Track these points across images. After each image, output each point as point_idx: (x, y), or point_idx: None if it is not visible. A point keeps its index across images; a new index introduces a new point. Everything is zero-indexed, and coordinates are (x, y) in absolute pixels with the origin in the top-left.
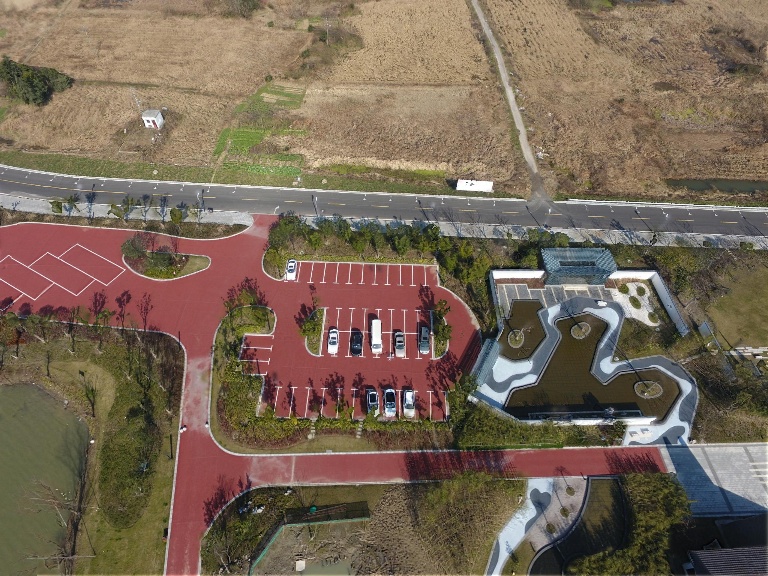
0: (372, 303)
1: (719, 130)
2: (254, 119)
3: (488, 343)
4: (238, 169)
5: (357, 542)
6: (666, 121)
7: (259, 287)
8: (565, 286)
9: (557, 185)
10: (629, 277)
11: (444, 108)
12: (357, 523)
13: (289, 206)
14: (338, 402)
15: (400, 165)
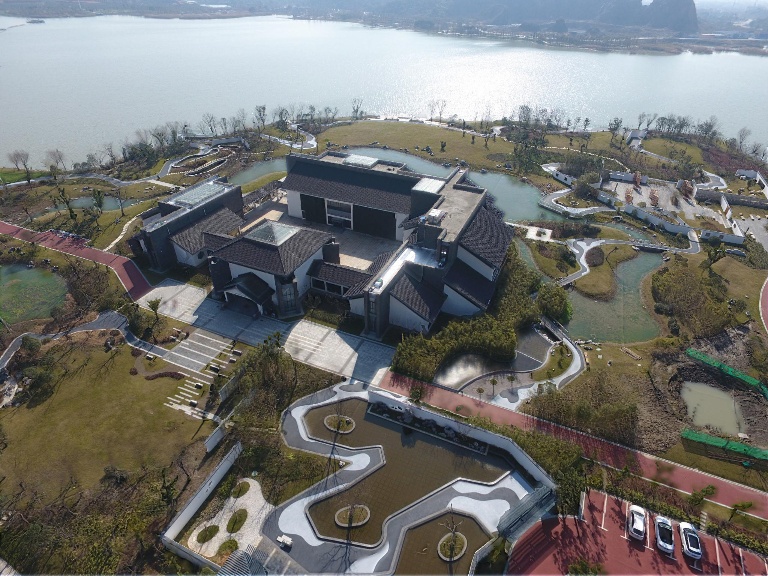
0: None
1: None
2: None
3: (513, 536)
4: None
5: (693, 425)
6: None
7: None
8: None
9: None
10: None
11: None
12: None
13: None
14: (744, 570)
15: None
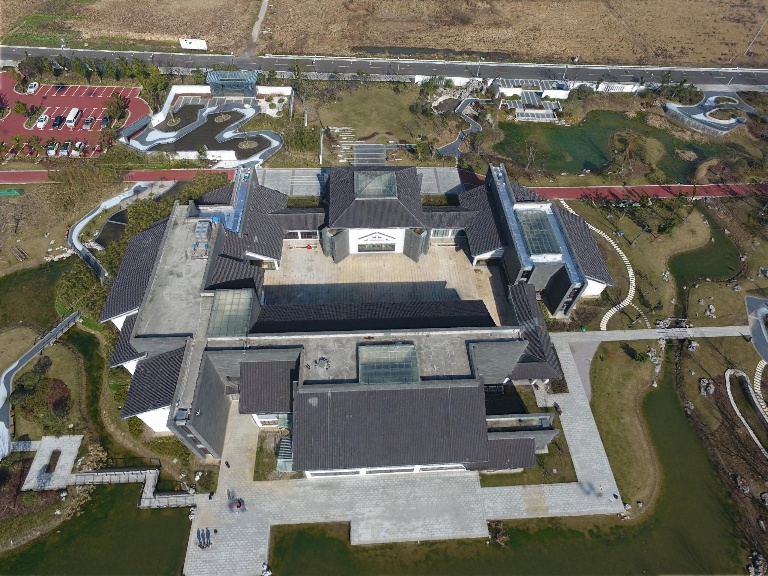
0: (83, 105)
1: (416, 19)
2: (48, 8)
3: None
4: (22, 37)
5: (7, 203)
6: (380, 14)
7: (6, 97)
8: (227, 97)
9: (264, 48)
10: (276, 93)
11: (209, 5)
12: (12, 196)
13: (52, 58)
14: (32, 149)
15: (151, 36)
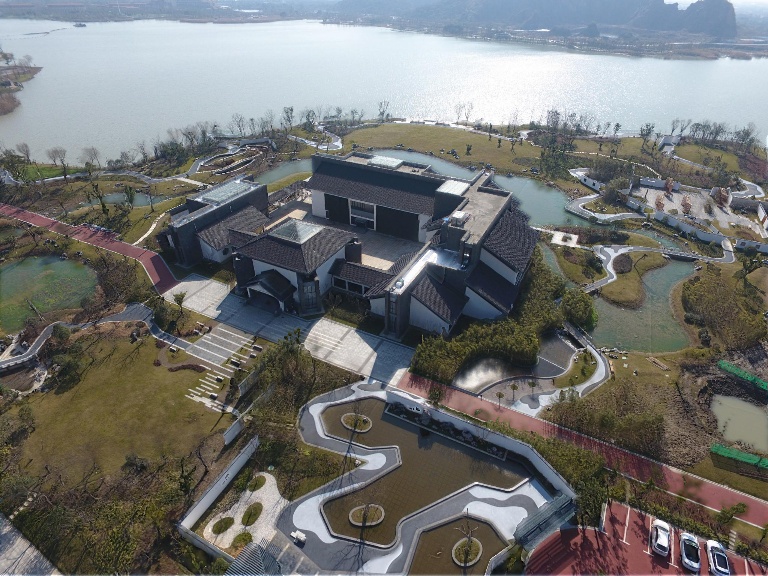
0: None
1: None
2: None
3: (530, 544)
4: None
5: (723, 440)
6: None
7: None
8: None
9: None
10: None
11: None
12: None
13: None
14: None
15: None
